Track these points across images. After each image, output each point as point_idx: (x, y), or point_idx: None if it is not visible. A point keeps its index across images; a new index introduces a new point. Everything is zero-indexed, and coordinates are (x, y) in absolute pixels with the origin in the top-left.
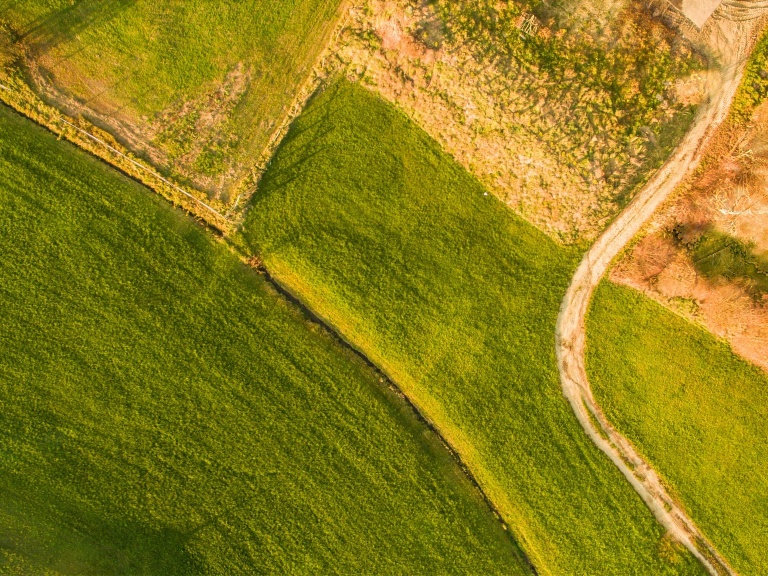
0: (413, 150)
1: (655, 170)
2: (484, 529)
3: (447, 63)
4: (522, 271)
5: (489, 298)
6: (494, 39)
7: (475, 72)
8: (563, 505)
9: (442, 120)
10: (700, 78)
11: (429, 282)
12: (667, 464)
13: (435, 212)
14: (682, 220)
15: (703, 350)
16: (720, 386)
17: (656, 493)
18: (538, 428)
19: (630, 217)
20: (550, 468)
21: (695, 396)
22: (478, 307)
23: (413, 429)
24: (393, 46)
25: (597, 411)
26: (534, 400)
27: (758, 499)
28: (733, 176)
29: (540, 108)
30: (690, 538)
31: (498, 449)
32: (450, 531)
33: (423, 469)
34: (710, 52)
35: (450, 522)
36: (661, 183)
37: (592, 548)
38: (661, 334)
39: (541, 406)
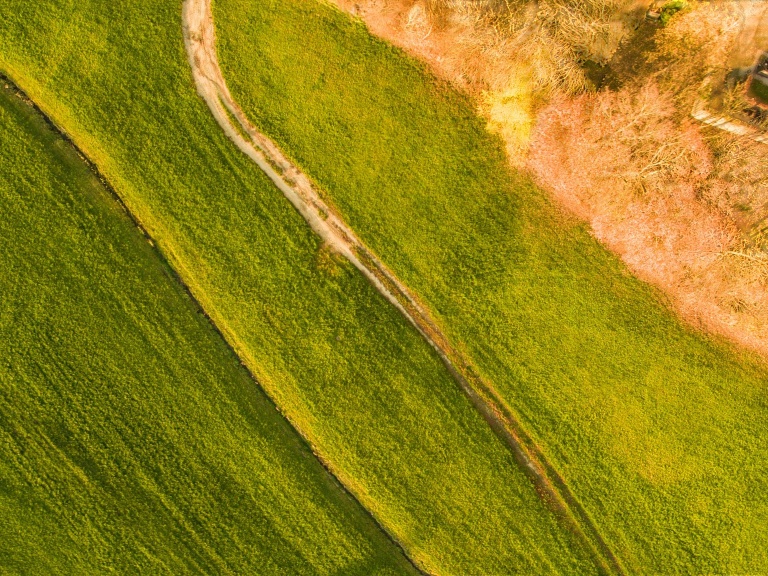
0: None
1: None
2: (129, 245)
3: None
4: None
5: None
6: None
7: None
8: (210, 216)
9: None
10: None
11: None
12: (317, 166)
13: None
14: None
15: (339, 33)
16: (362, 73)
17: (309, 200)
18: (175, 131)
19: None
20: (192, 175)
21: (336, 86)
22: None
23: (44, 138)
24: None
25: (237, 110)
26: (168, 101)
27: (419, 201)
28: None
29: None
30: (351, 249)
31: (135, 157)
32: (92, 248)
33: (57, 180)
34: None
35: (91, 238)
36: None
37: (246, 263)
38: (292, 18)
39: (176, 107)
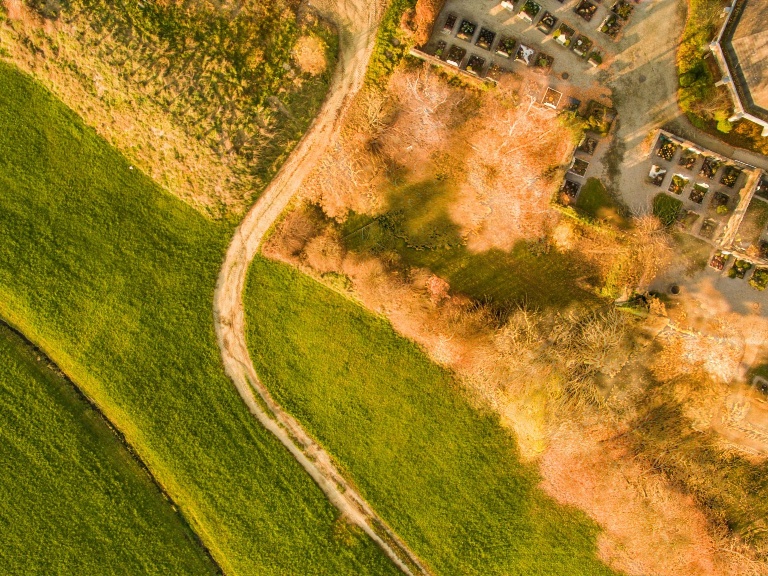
0: (55, 123)
1: (294, 142)
2: (152, 511)
3: (68, 33)
4: (174, 247)
5: (142, 274)
6: (113, 8)
7: (96, 42)
8: (232, 486)
9: (77, 92)
10: (329, 46)
11: (80, 258)
12: (337, 444)
13: (82, 187)
14: (321, 193)
15: (364, 327)
16: (384, 364)
17: (328, 474)
18: (202, 407)
19: (277, 191)
20: (216, 448)
21: (360, 374)
22: (132, 284)
23: (74, 408)
24: (17, 16)
25: (262, 390)
26: (196, 379)
27: (433, 480)
28: (361, 146)
29: (162, 78)
30: (366, 520)
31: (162, 429)
32: (117, 512)
33: (85, 449)
34: (339, 20)
35: (116, 503)
36: (304, 155)
37: (265, 530)
38: (320, 311)
39: (204, 385)
